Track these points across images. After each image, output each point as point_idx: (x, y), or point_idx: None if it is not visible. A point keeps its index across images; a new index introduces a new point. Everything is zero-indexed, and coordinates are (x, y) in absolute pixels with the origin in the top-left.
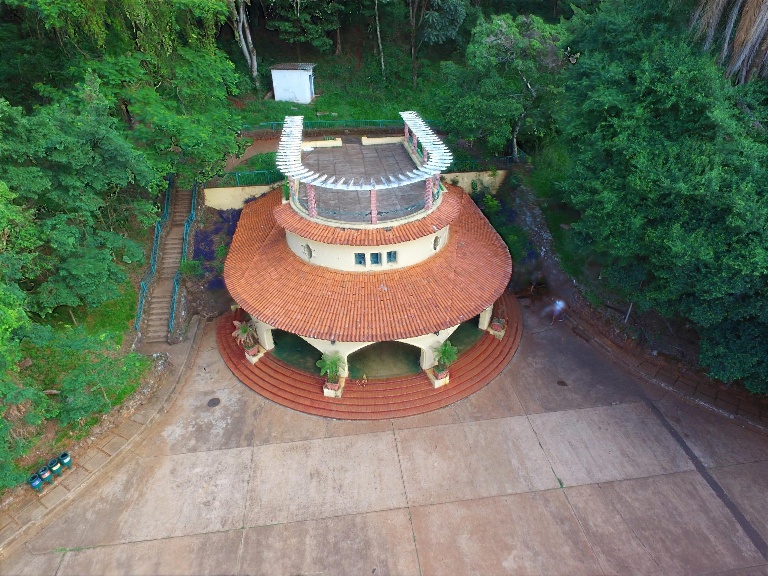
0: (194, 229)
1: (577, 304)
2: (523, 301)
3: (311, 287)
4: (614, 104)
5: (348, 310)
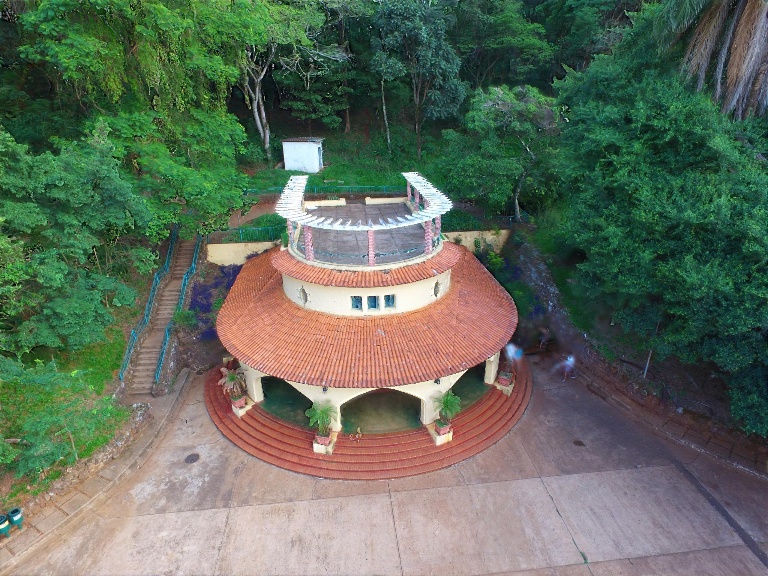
0: (193, 282)
1: (590, 360)
2: (532, 358)
3: (304, 332)
4: (612, 142)
5: (342, 355)
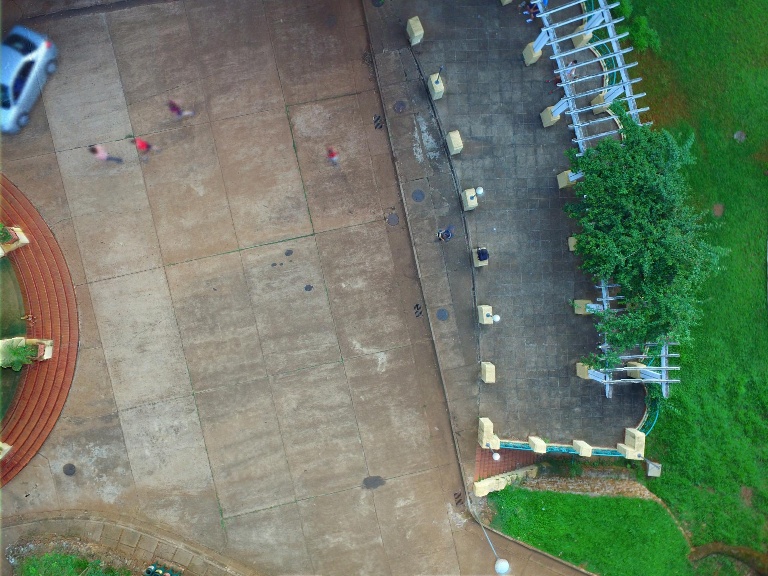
0: None
1: None
2: None
3: None
4: None
5: None
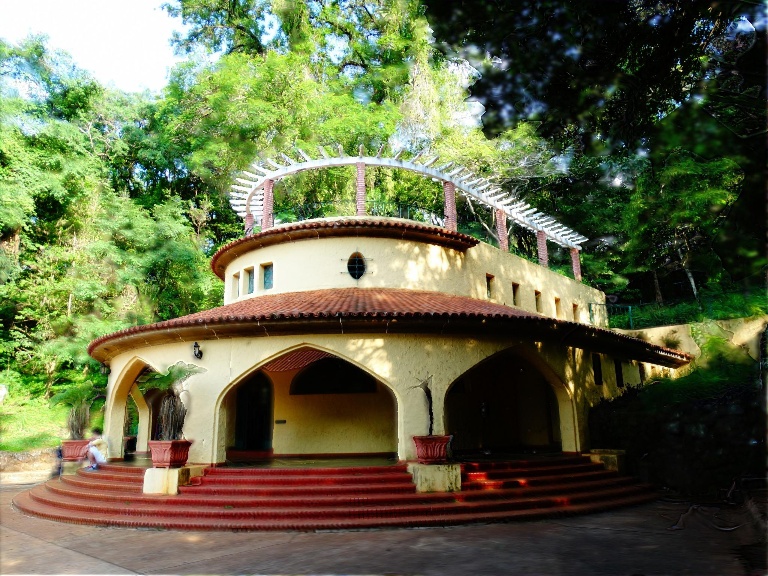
0: None
1: None
2: (670, 504)
3: None
4: None
5: None
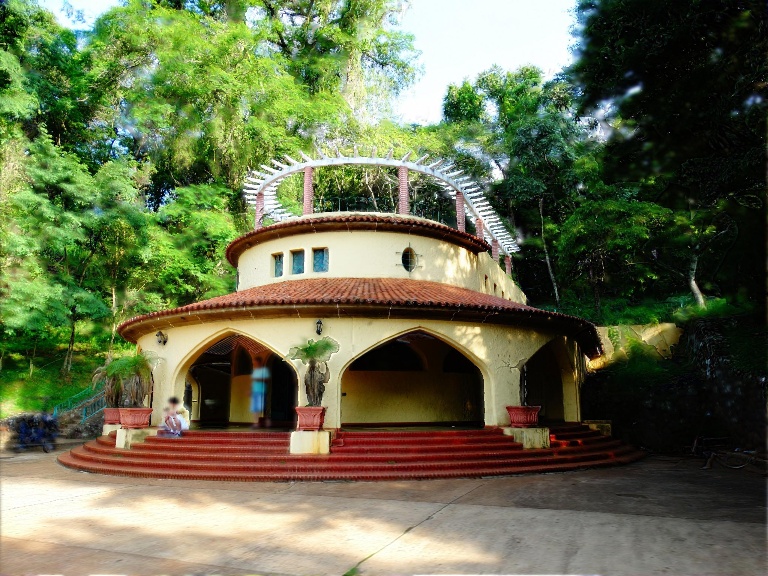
0: None
1: None
2: (661, 457)
3: None
4: None
5: None
